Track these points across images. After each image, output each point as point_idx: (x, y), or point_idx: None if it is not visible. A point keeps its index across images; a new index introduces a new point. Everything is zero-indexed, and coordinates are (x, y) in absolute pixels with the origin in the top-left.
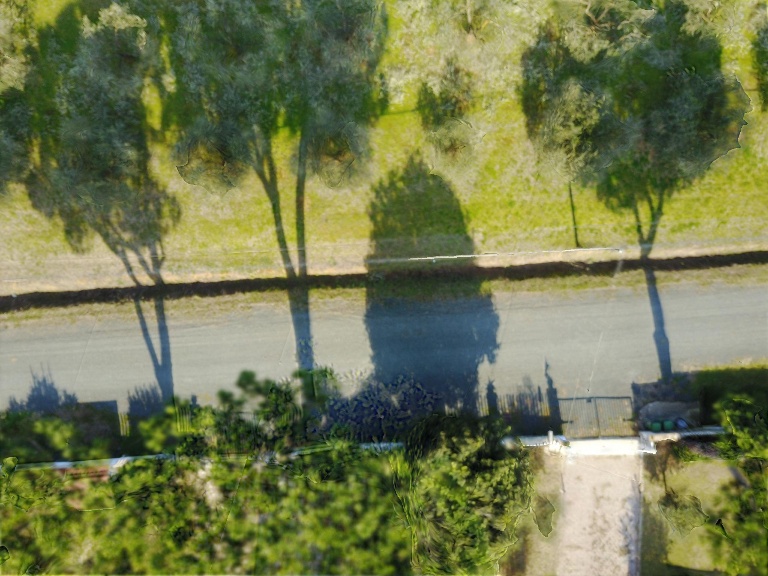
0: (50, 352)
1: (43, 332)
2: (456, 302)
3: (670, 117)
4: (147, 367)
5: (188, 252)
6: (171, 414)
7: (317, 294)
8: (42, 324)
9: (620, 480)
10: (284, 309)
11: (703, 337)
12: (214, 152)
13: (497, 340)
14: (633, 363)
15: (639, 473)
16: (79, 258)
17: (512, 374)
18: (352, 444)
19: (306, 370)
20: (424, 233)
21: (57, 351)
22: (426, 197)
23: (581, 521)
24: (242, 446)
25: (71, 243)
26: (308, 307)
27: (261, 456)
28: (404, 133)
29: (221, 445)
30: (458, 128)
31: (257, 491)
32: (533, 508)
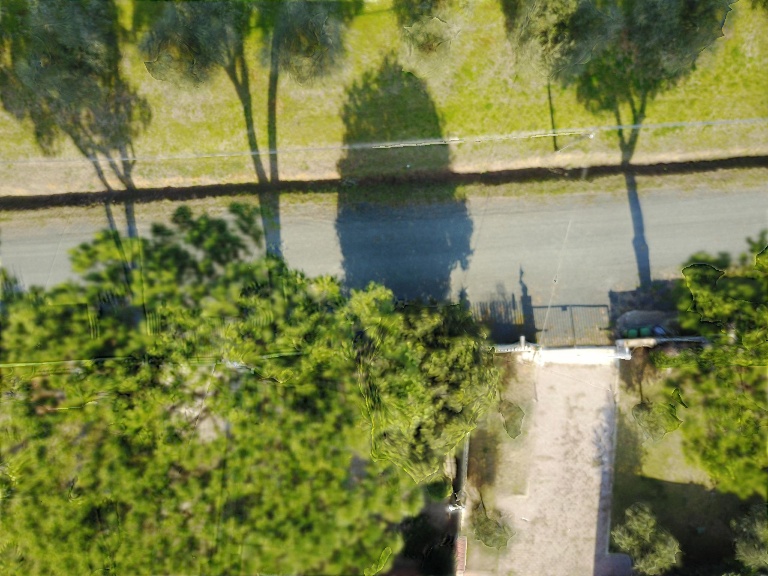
0: (21, 254)
1: (15, 234)
2: (429, 207)
3: (651, 7)
4: (117, 270)
5: (159, 155)
6: (141, 318)
7: (288, 199)
8: (14, 226)
9: (595, 390)
10: (255, 213)
11: (685, 244)
12: (183, 50)
13: (471, 246)
14: (611, 271)
15: (615, 383)
16: (51, 161)
17: (486, 281)
18: (321, 349)
19: (276, 275)
20: (398, 137)
21: (28, 253)
22: (400, 100)
23: (554, 431)
24: (211, 350)
25: (43, 145)
26: (279, 211)
27: (229, 360)
28: (378, 33)
29: (190, 349)
30: (431, 21)
31: (226, 396)
32: (502, 412)
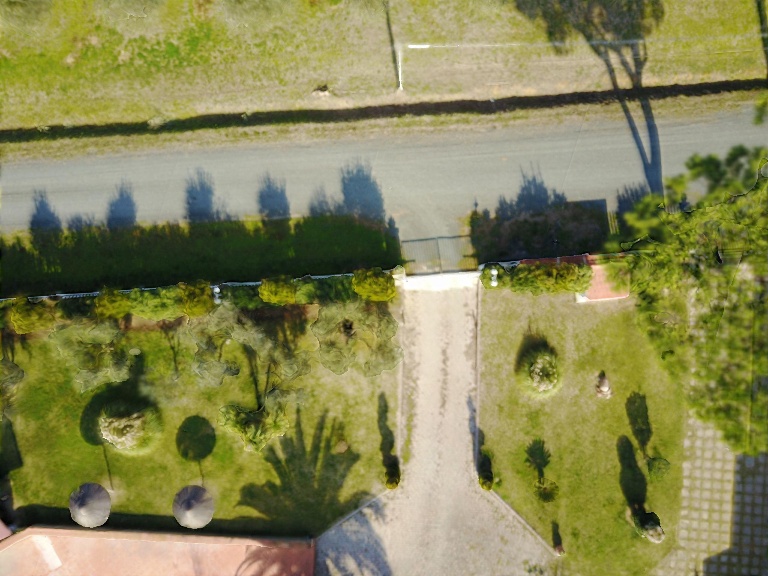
0: (539, 151)
1: (531, 132)
2: None
3: None
4: (636, 165)
5: (671, 52)
6: None
7: None
8: (529, 124)
9: None
10: None
11: None
12: None
13: None
14: None
15: None
16: (562, 60)
17: None
18: None
19: None
20: None
21: (546, 150)
22: None
23: None
24: (736, 242)
25: (555, 44)
26: None
27: (762, 249)
28: None
29: None
30: None
31: (751, 287)
32: None
